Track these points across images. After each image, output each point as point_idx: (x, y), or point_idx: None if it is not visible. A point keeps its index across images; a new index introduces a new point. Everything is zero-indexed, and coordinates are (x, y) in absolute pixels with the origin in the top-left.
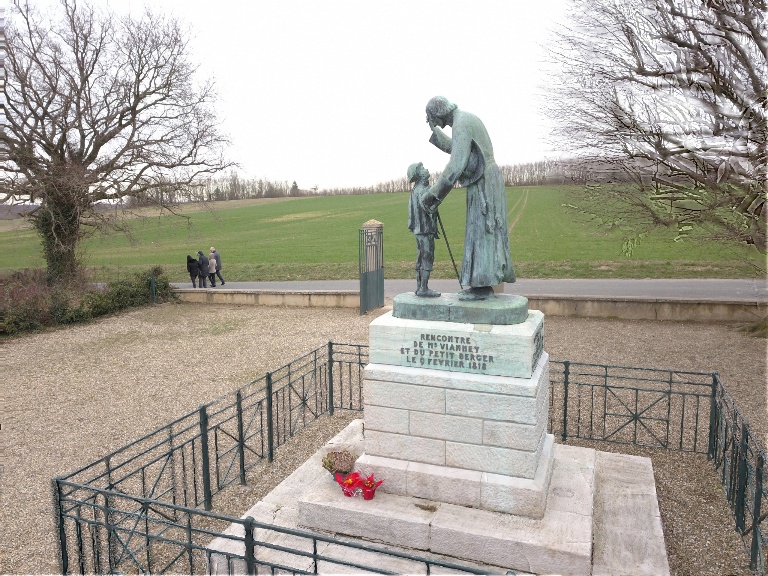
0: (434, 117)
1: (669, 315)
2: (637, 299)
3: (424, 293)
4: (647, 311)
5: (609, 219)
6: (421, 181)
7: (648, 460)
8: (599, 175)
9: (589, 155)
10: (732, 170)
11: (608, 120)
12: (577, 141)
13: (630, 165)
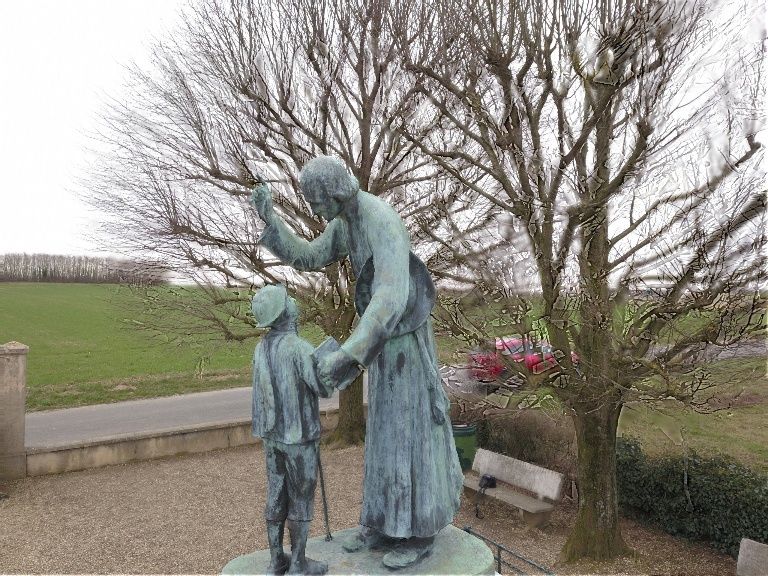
0: (326, 197)
1: (242, 439)
2: (209, 427)
3: (303, 574)
4: (219, 439)
5: (178, 336)
6: (290, 326)
7: None
8: (162, 284)
9: (149, 259)
10: (311, 285)
11: (161, 221)
12: (131, 241)
13: (202, 274)
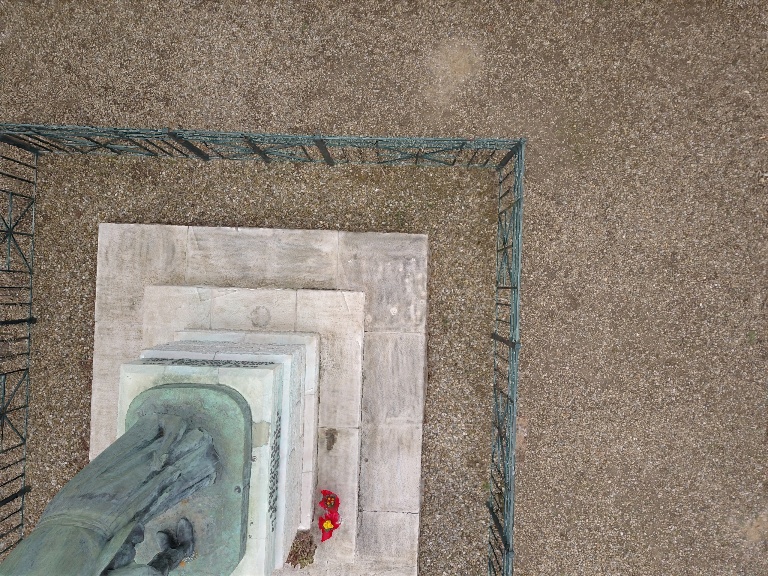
0: None
1: None
2: None
3: (192, 544)
4: None
5: None
6: None
7: (108, 227)
8: None
9: None
10: None
11: None
12: None
13: None
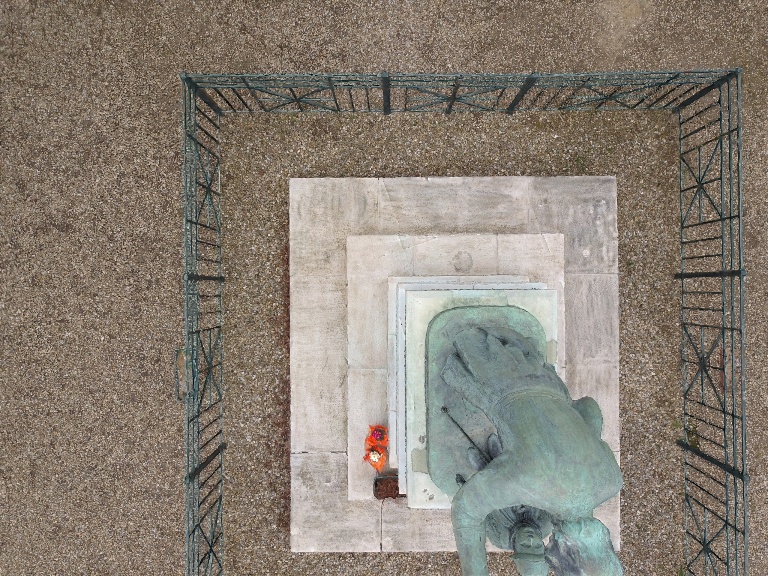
0: None
1: None
2: None
3: None
4: None
5: None
6: None
7: (299, 181)
8: None
9: None
10: None
11: None
12: None
13: None
